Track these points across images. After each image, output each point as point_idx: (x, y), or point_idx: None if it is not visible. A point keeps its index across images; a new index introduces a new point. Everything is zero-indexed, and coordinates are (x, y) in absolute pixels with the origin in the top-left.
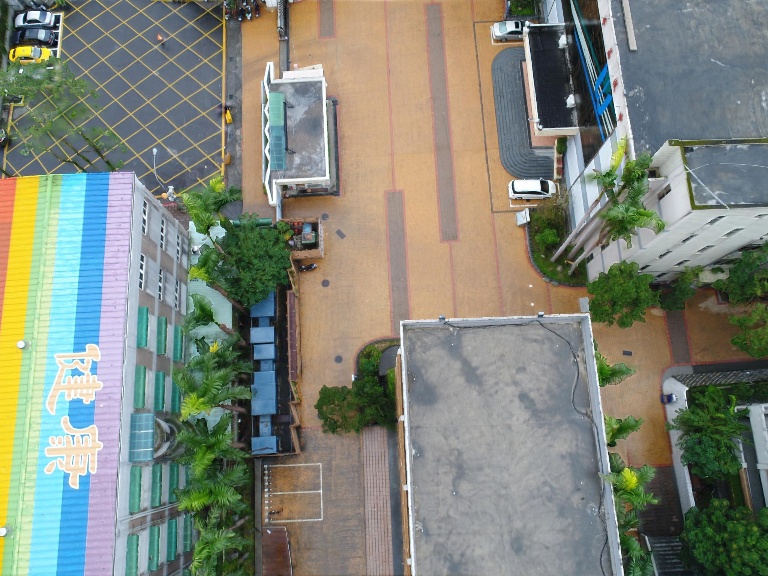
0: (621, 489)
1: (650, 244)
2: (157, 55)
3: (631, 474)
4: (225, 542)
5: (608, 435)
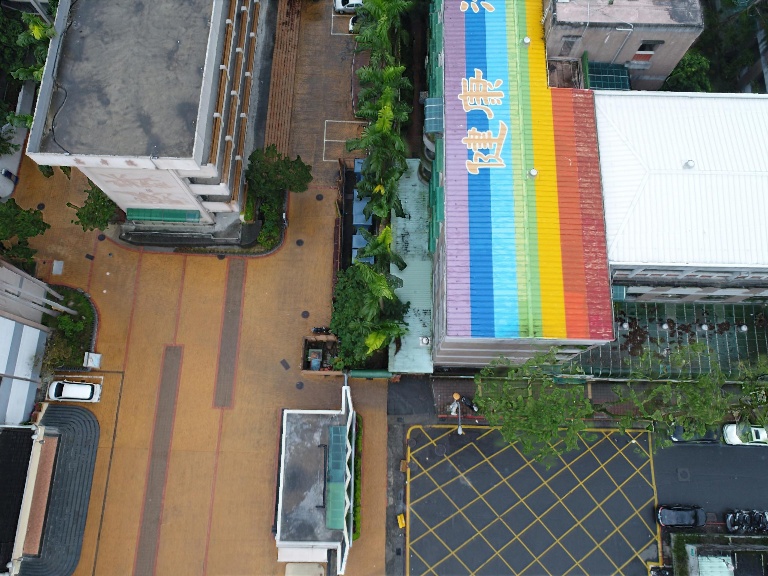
0: None
1: None
2: None
3: (34, 32)
4: (363, 33)
5: None
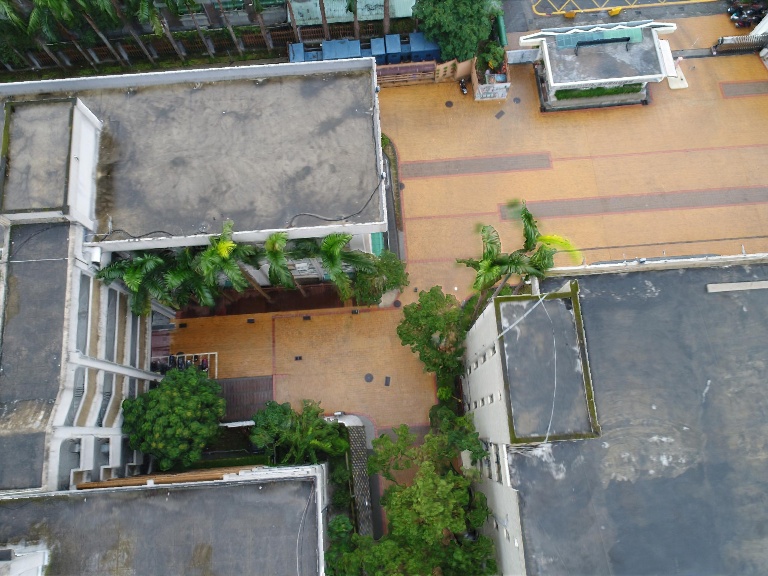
0: None
1: None
2: None
3: (229, 246)
4: None
5: (269, 239)
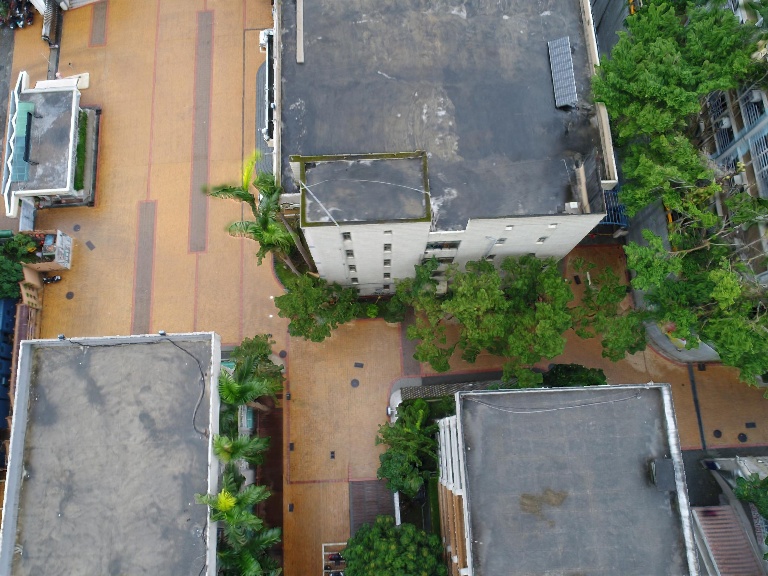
0: (220, 510)
1: (317, 259)
2: None
3: (224, 496)
4: None
5: (219, 455)
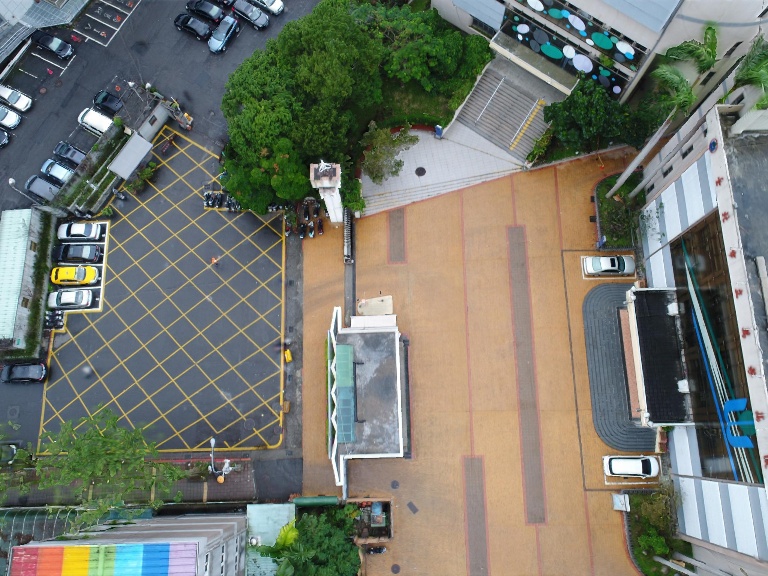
0: None
1: None
2: (210, 276)
3: None
4: None
5: None
